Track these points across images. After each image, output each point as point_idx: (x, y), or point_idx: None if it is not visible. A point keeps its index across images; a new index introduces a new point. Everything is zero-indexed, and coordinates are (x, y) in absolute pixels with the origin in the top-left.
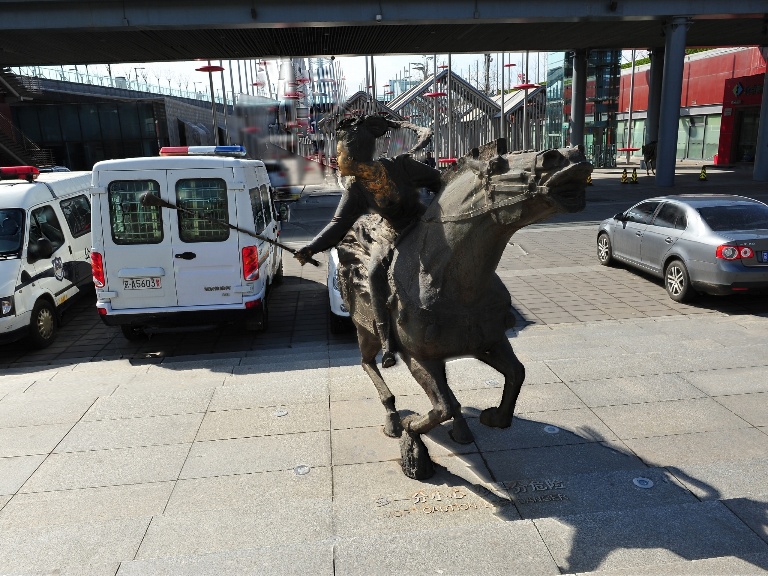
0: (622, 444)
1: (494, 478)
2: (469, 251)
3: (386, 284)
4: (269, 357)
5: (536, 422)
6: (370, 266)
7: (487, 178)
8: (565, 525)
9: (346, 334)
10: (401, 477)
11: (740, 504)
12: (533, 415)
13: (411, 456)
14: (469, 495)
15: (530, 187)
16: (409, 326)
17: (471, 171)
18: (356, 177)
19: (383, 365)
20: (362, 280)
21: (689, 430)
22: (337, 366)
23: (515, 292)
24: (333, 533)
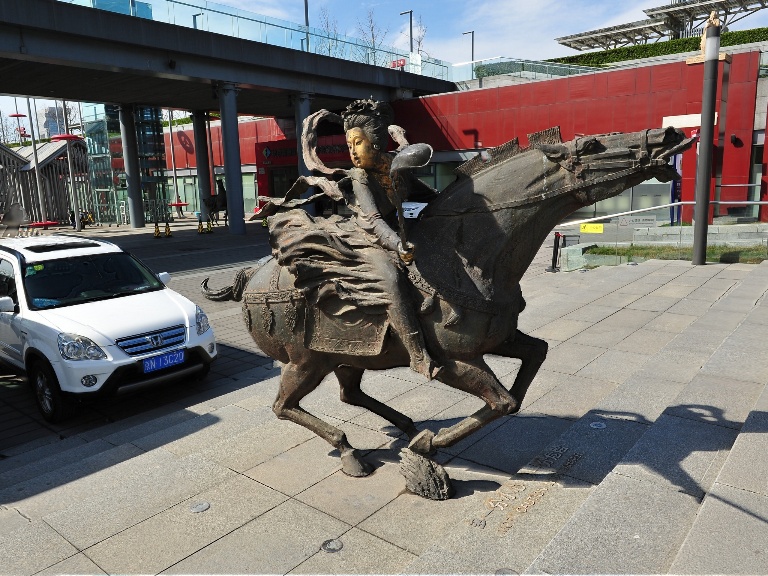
0: (530, 412)
1: (499, 469)
2: (529, 235)
3: (410, 289)
4: (15, 471)
5: (454, 419)
6: (389, 271)
7: (576, 159)
8: (633, 465)
9: (73, 420)
10: (433, 503)
11: (673, 411)
12: (444, 414)
13: (436, 476)
14: (526, 484)
15: (641, 161)
16: (467, 324)
17: (526, 157)
18: (368, 171)
19: (432, 376)
20: (352, 294)
21: (547, 389)
22: (153, 446)
23: (222, 336)
24: (491, 570)
